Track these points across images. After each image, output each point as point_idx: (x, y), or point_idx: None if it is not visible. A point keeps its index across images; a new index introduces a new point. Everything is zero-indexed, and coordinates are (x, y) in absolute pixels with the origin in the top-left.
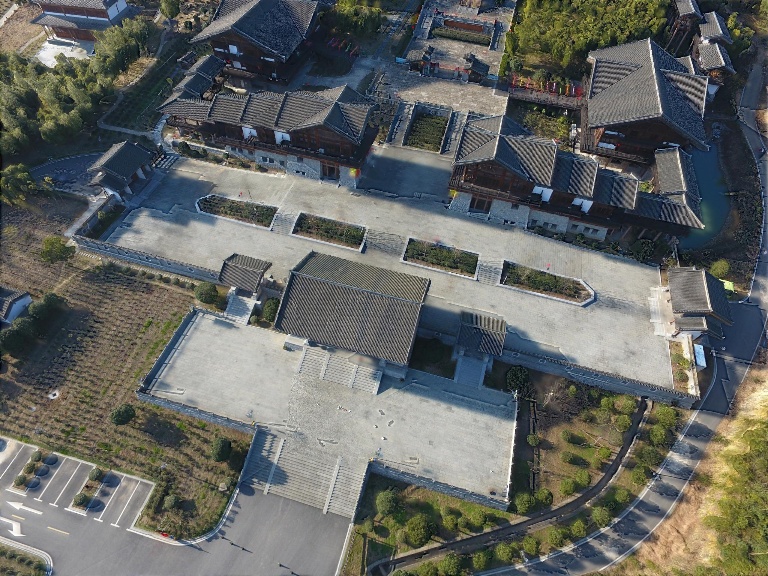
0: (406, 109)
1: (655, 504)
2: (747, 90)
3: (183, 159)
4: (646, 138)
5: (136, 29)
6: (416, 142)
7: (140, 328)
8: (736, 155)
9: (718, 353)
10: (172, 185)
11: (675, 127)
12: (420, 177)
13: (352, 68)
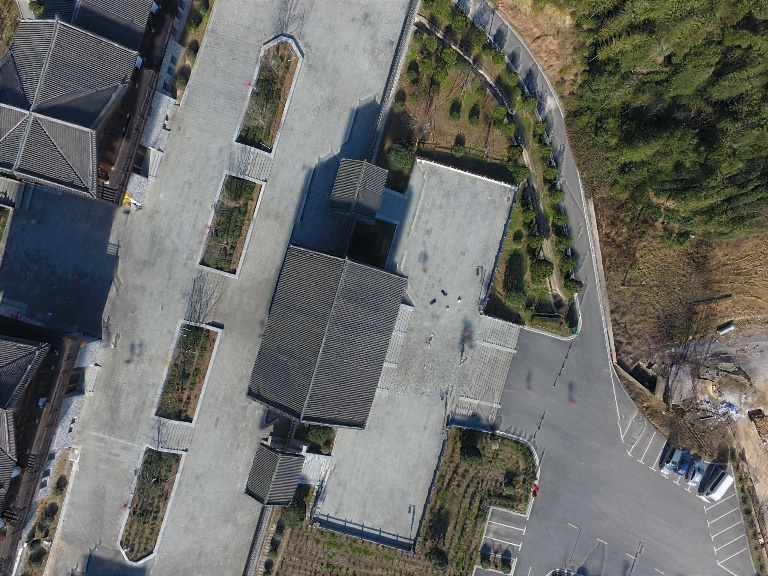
0: None
1: (514, 50)
2: None
3: None
4: None
5: None
6: None
7: (335, 574)
8: None
9: None
10: None
11: None
12: (72, 243)
13: None
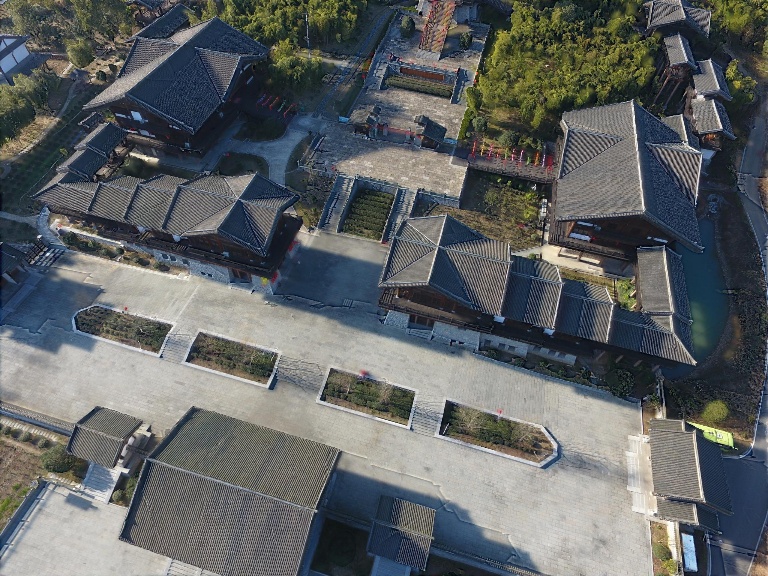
0: (344, 185)
1: None
2: (748, 151)
3: (70, 253)
4: (627, 232)
5: (29, 87)
6: (353, 228)
7: None
8: (736, 239)
9: (713, 539)
10: (49, 291)
11: (661, 226)
12: (354, 277)
13: (287, 130)
